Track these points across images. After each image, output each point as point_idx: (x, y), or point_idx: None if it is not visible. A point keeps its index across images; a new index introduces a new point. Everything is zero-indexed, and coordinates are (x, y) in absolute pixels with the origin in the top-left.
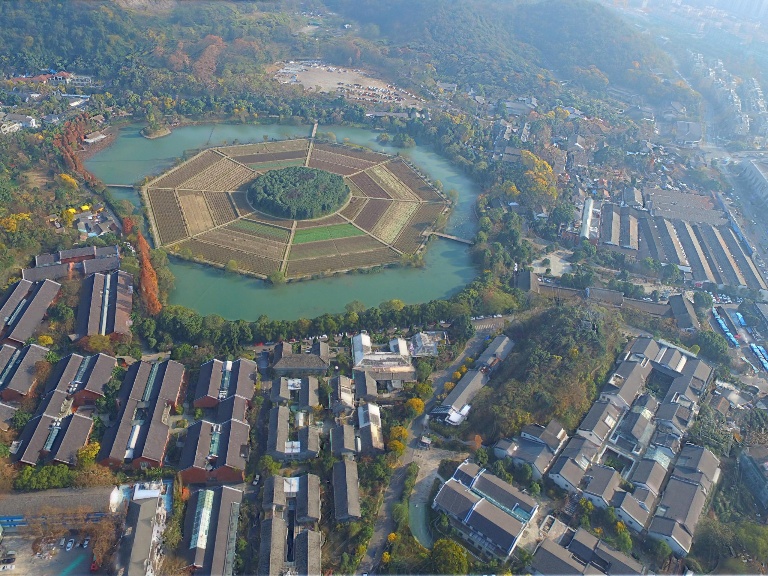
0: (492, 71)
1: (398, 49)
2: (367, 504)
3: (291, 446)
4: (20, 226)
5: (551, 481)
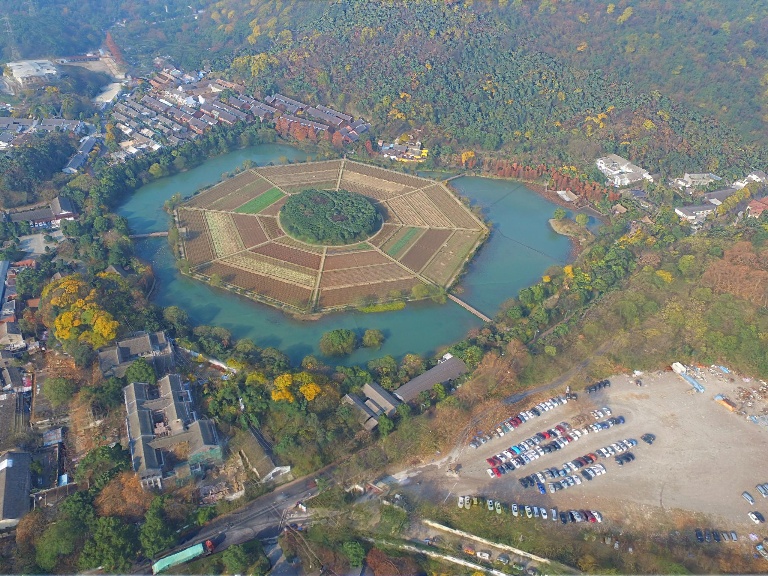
0: None
1: None
2: None
3: None
4: None
5: None
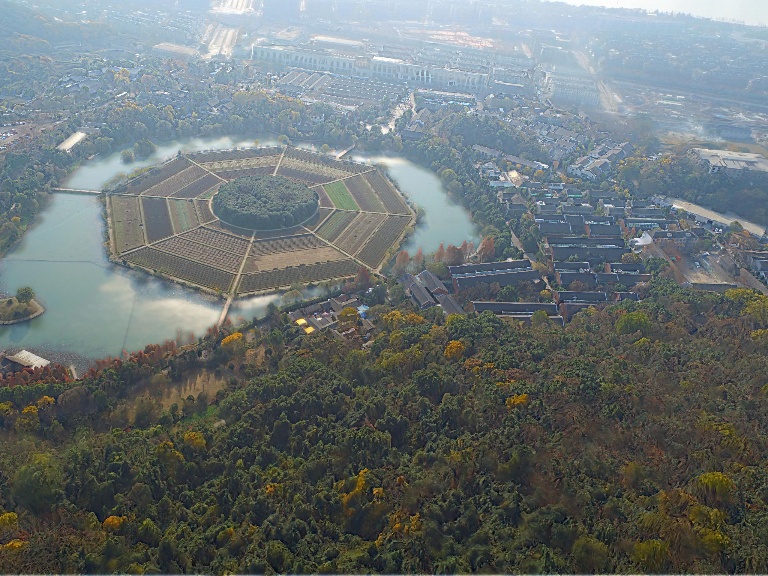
0: None
1: None
2: None
3: None
4: None
5: None
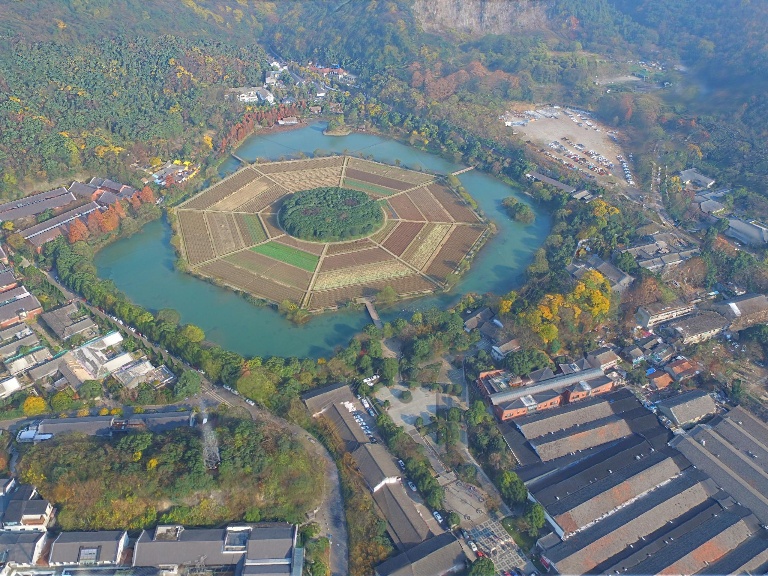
0: None
1: (679, 120)
2: None
3: None
4: (106, 154)
5: None
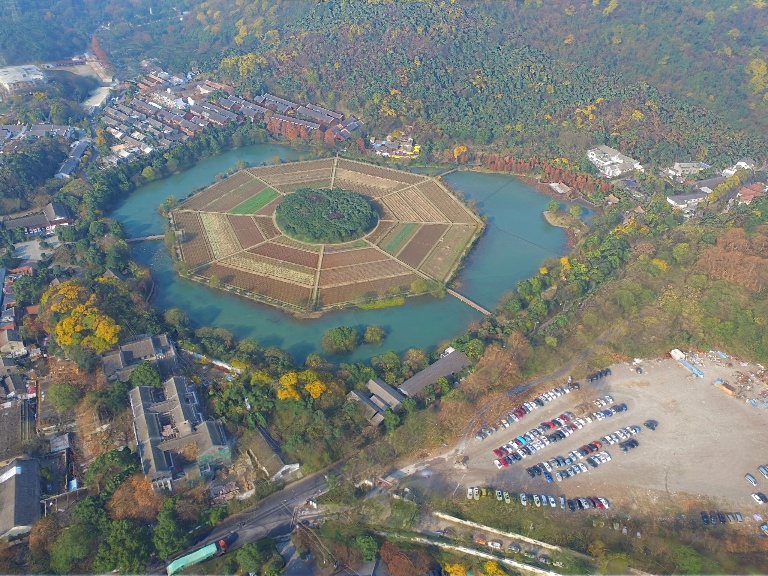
0: None
1: None
2: None
3: None
4: None
5: None
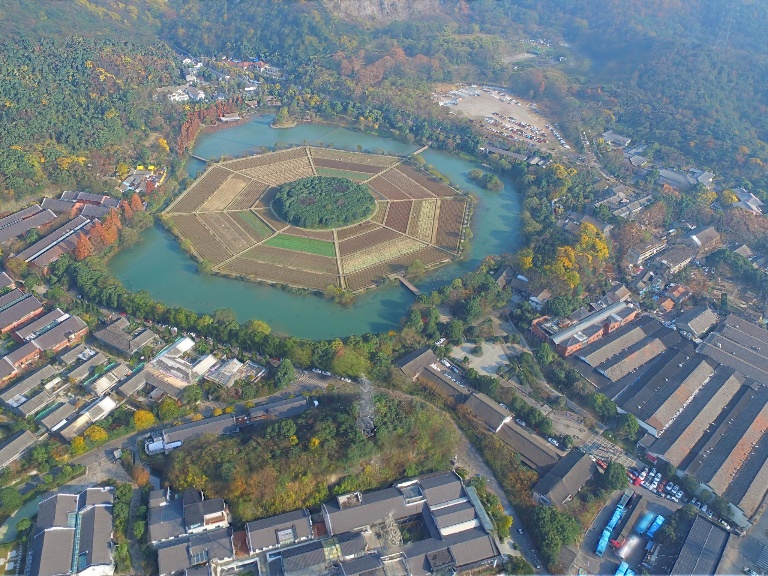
0: (683, 132)
1: (587, 89)
2: (3, 476)
3: (18, 399)
4: (70, 166)
5: (156, 555)
